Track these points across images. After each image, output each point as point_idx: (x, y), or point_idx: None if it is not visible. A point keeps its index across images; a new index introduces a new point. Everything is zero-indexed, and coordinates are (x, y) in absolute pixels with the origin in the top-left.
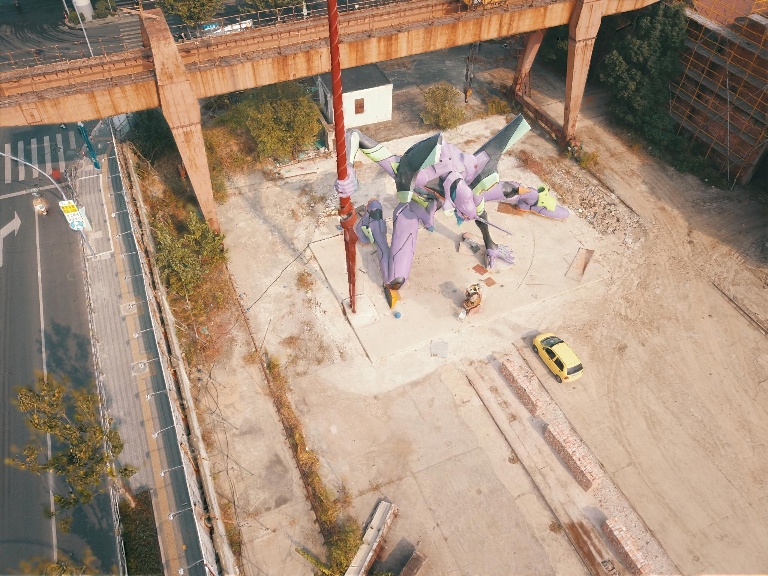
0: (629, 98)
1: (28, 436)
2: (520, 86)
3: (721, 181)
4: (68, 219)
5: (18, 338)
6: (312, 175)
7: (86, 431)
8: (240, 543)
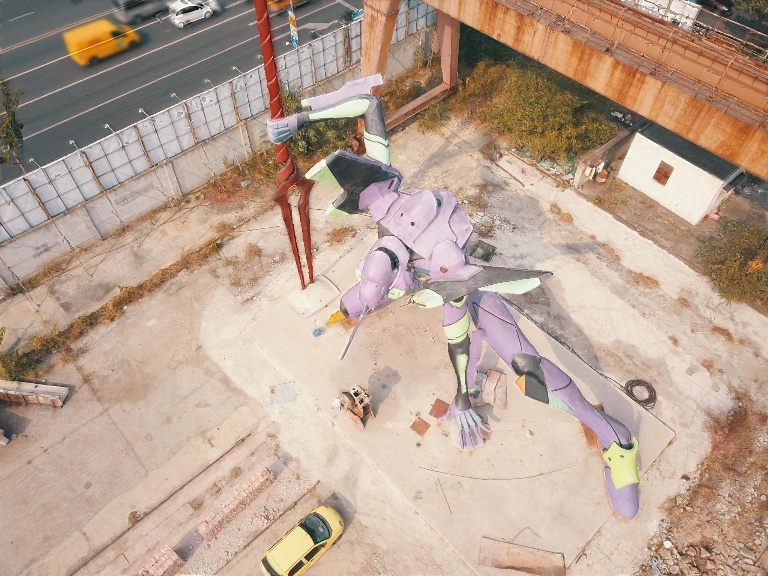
0: None
1: None
2: None
3: None
4: (292, 31)
5: (201, 82)
6: (517, 184)
7: (8, 112)
8: (24, 291)
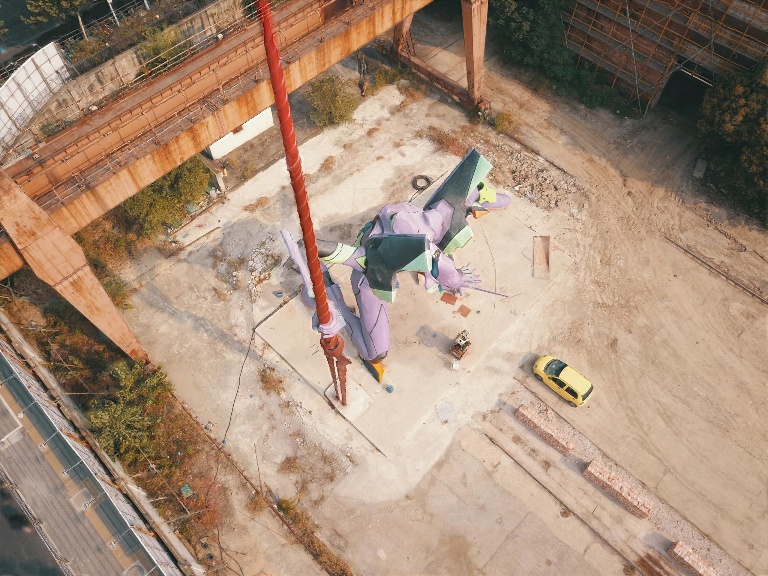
0: (524, 39)
1: None
2: (402, 45)
3: (632, 110)
4: None
5: None
6: (216, 232)
7: None
8: None
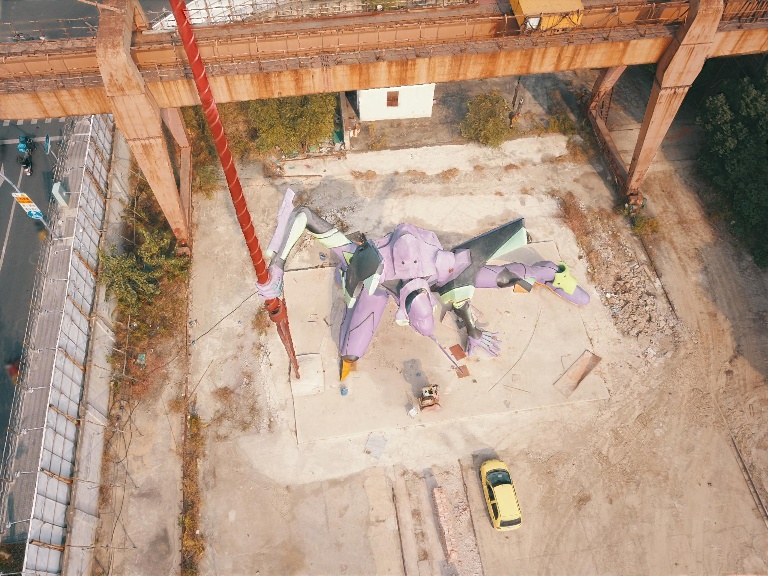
0: (724, 156)
1: None
2: (597, 103)
3: None
4: (25, 208)
5: None
6: (316, 178)
7: None
8: None
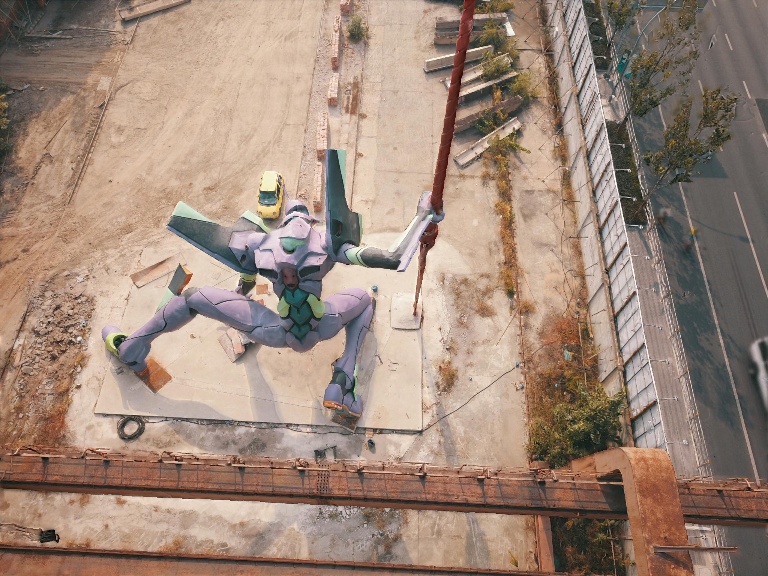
0: None
1: (729, 306)
2: None
3: None
4: None
5: None
6: None
7: None
8: None
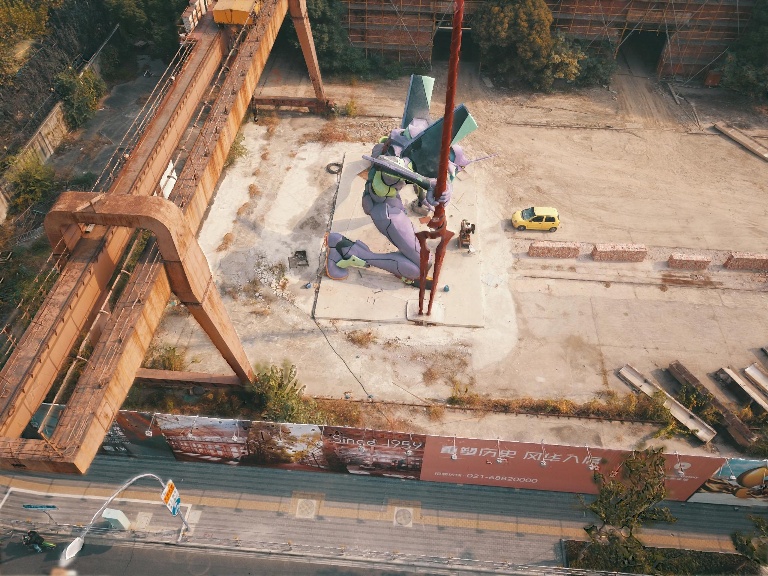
0: (327, 49)
1: None
2: None
3: (422, 69)
4: (170, 509)
5: None
6: None
7: None
8: None
